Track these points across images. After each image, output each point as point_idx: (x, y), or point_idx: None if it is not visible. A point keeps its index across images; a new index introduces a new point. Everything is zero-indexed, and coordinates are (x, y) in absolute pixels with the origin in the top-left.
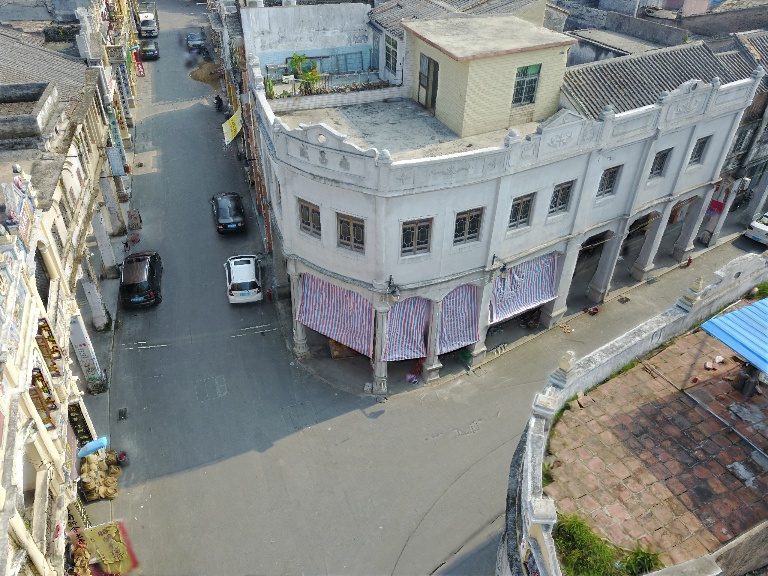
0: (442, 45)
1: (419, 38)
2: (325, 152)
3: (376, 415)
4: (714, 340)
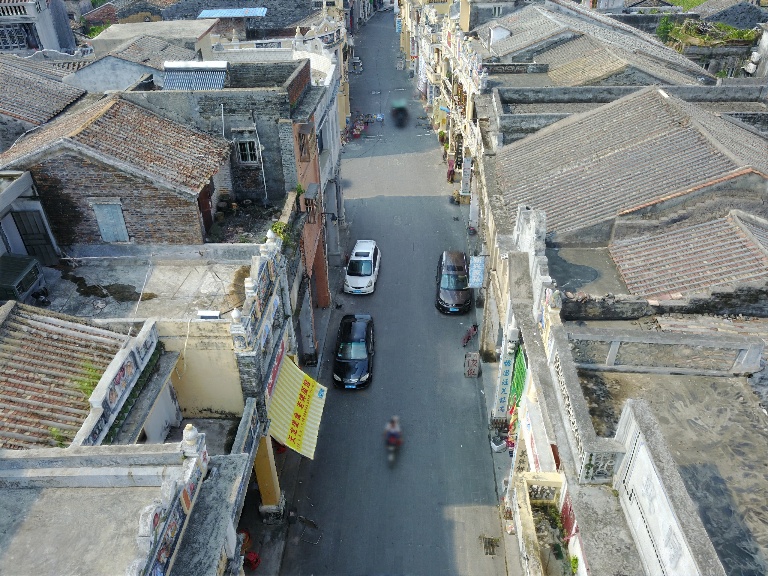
0: None
1: None
2: None
3: None
4: None
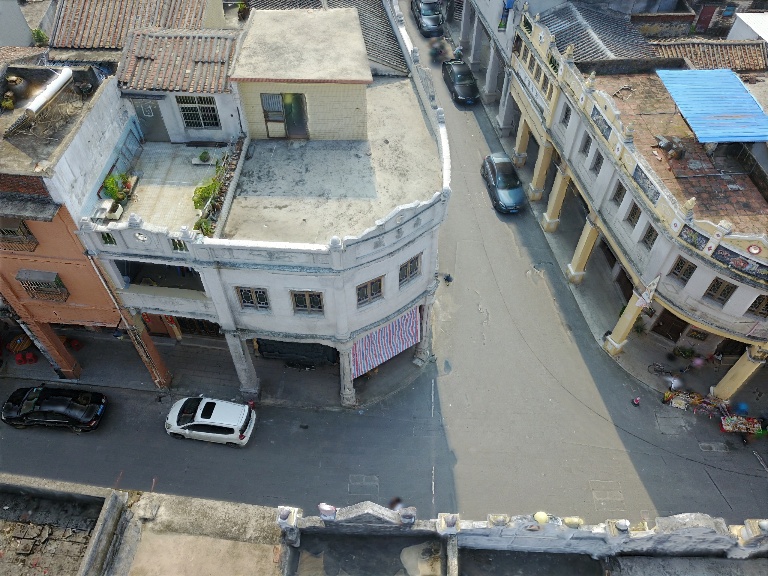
0: (331, 77)
1: (285, 82)
2: (402, 227)
3: (448, 368)
4: (637, 146)
